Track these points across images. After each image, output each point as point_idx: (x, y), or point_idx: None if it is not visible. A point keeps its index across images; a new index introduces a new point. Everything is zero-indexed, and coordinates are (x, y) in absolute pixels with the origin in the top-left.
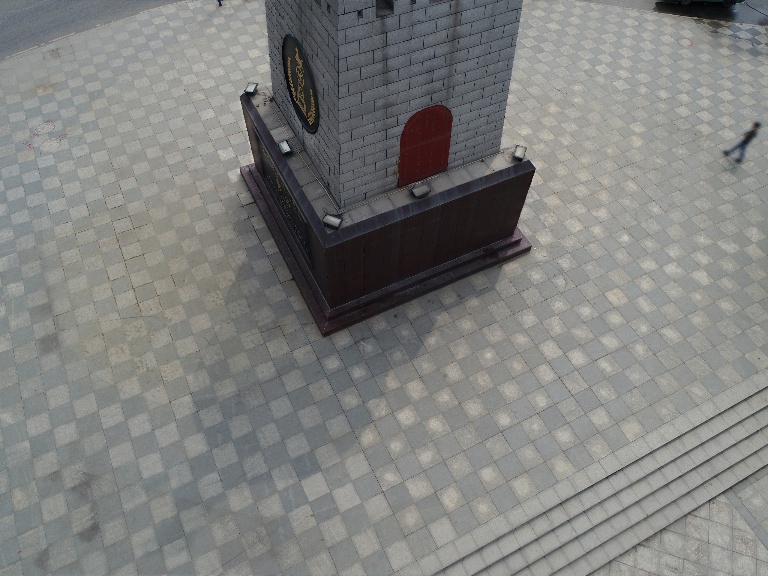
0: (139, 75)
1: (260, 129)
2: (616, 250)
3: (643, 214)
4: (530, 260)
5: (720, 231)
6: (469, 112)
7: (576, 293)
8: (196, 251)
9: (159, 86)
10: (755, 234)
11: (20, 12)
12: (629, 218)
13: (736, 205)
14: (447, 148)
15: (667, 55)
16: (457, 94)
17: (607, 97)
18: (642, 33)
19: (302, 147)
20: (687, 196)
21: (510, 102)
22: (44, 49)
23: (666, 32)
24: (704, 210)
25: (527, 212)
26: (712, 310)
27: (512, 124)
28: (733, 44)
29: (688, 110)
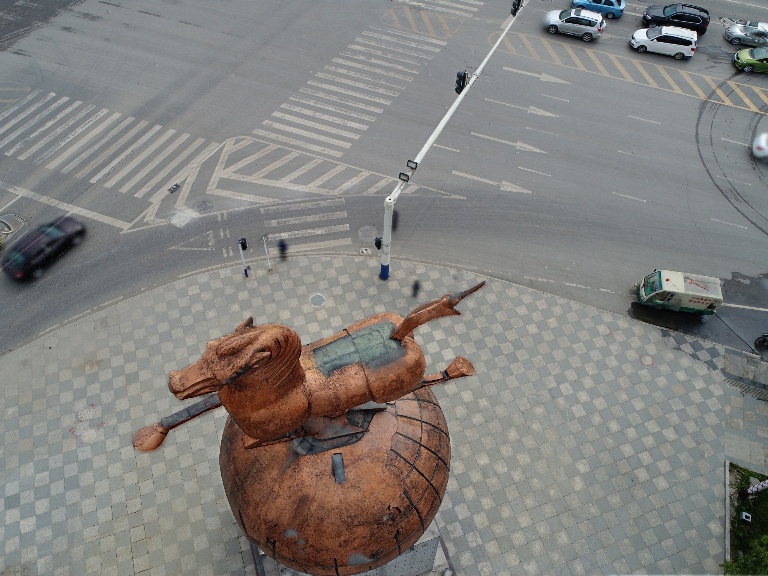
0: (169, 358)
1: None
2: None
3: (567, 573)
4: None
5: None
6: (401, 573)
7: None
8: (192, 570)
9: None
10: None
11: (81, 267)
12: (554, 575)
13: (650, 572)
14: None
15: (627, 376)
16: (389, 574)
17: (563, 425)
18: (610, 345)
19: None
20: (609, 555)
21: (477, 423)
22: (96, 317)
23: (632, 346)
24: (621, 574)
25: (468, 558)
26: None
27: (474, 450)
28: (691, 367)
29: (632, 449)
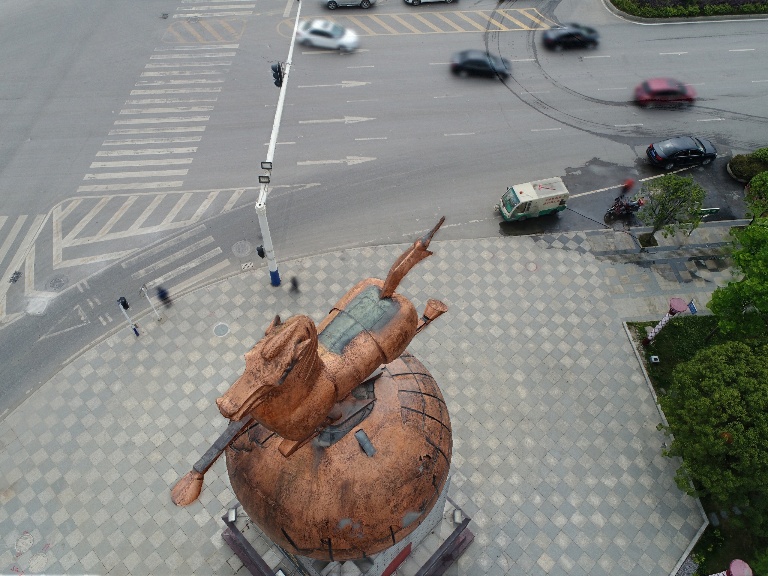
0: (91, 448)
1: (251, 553)
2: (534, 514)
3: (544, 469)
4: (476, 548)
5: (600, 467)
6: None
7: (517, 569)
8: None
9: (115, 456)
10: (624, 462)
11: None
12: (536, 477)
13: (605, 436)
14: (409, 549)
15: (522, 286)
16: None
17: (489, 349)
18: (498, 266)
19: (294, 568)
20: (570, 439)
21: None
22: None
23: (515, 259)
24: (585, 449)
25: (461, 497)
26: (612, 550)
27: None
28: (566, 258)
29: (551, 344)
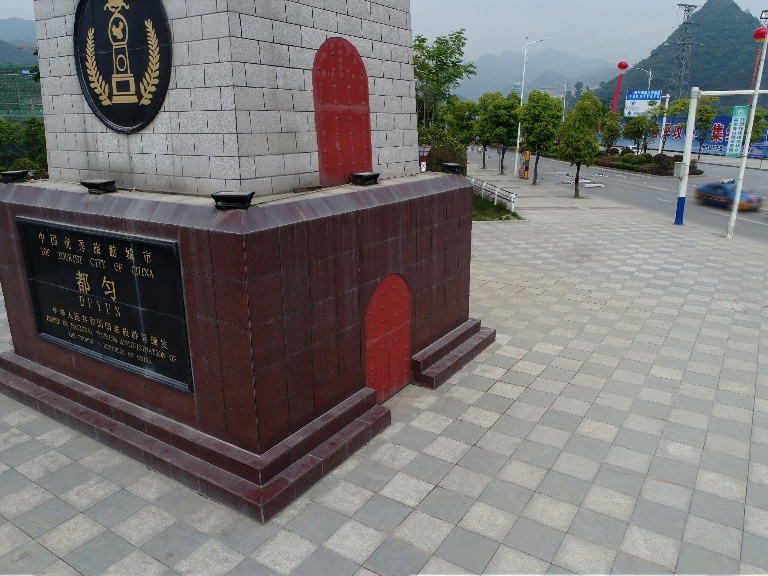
0: None
1: None
2: None
3: None
4: None
5: None
6: None
7: None
8: None
9: None
10: None
11: None
12: None
13: None
14: None
15: None
16: None
17: None
18: None
19: None
20: None
21: None
22: None
23: None
24: None
25: None
26: None
27: None
28: None
29: None
